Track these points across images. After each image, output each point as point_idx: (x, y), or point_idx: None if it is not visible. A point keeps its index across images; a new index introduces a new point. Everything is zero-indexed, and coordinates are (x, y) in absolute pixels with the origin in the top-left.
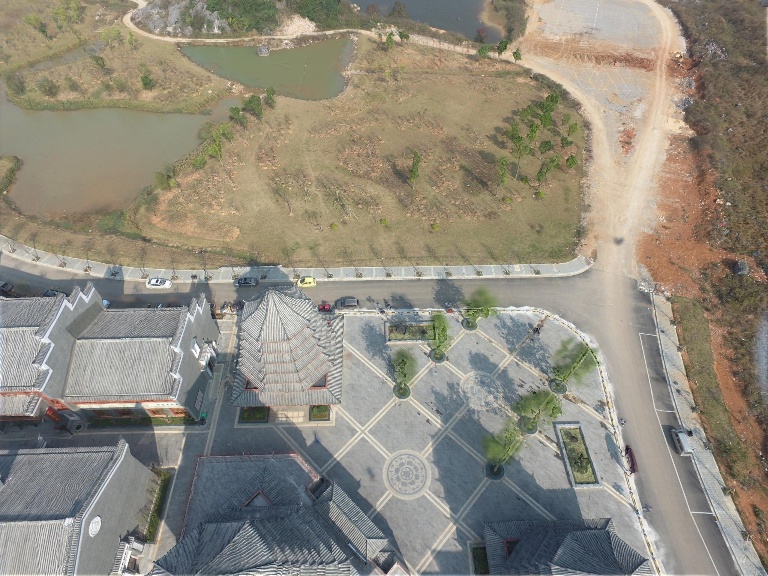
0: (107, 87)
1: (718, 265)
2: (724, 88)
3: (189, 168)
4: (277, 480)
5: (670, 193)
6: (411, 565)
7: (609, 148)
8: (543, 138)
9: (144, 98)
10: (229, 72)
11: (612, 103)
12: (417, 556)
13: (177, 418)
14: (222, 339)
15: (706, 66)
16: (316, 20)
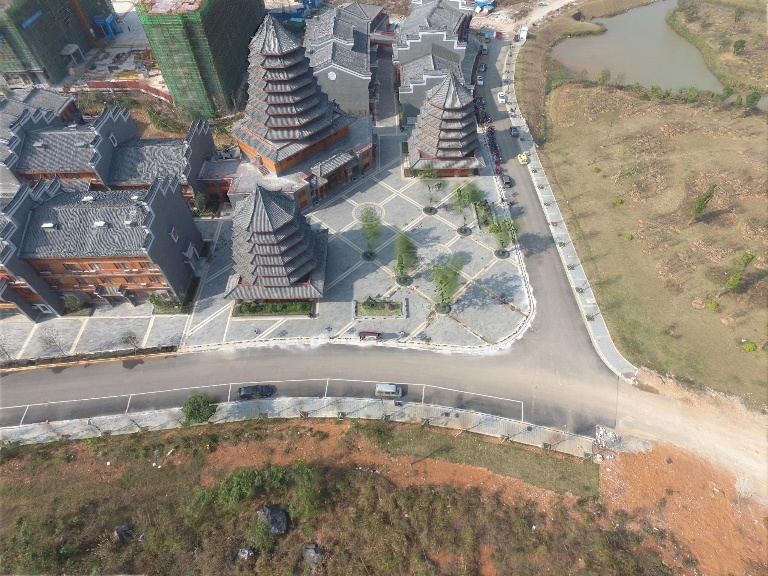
0: (720, 36)
1: (692, 568)
2: None
3: (639, 95)
4: (349, 123)
5: None
6: (315, 213)
7: None
8: None
9: (722, 56)
10: None
11: None
12: (319, 216)
13: None
14: None
15: None
16: None
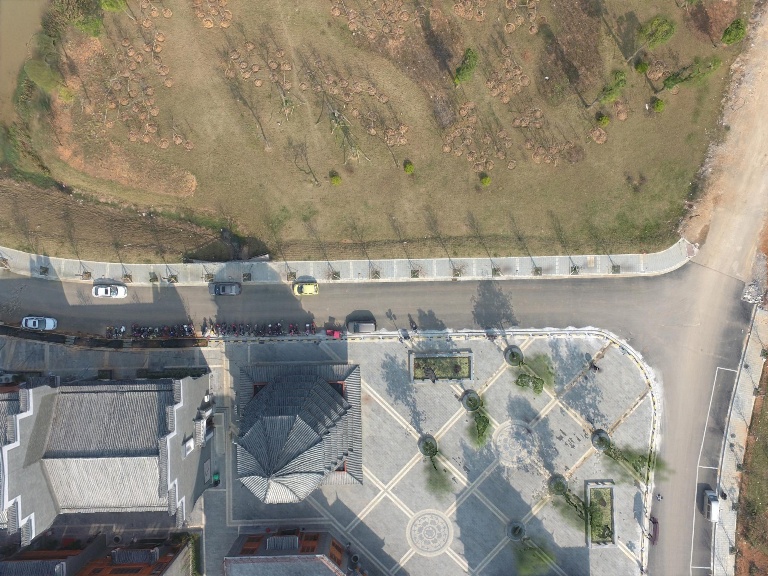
0: None
1: None
2: None
3: (78, 17)
4: None
5: None
6: None
7: None
8: None
9: None
10: None
11: None
12: None
13: None
14: (213, 377)
15: None
16: None
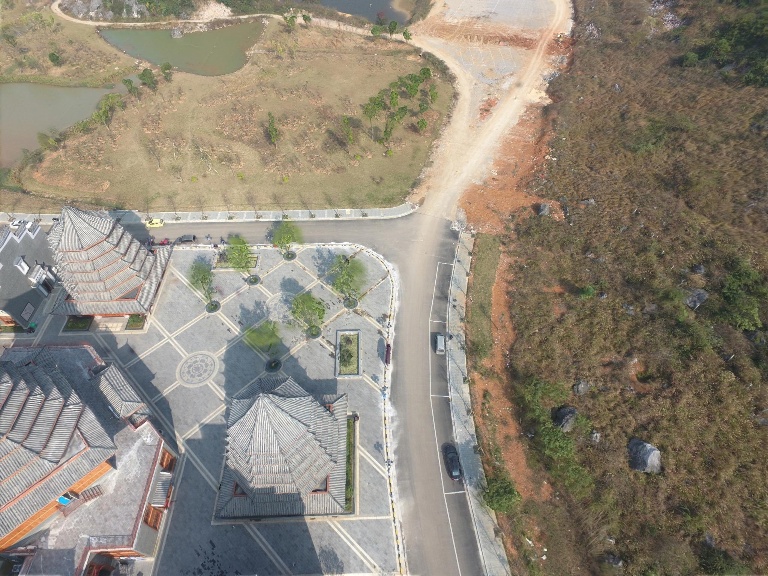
0: (20, 64)
1: (527, 208)
2: (588, 63)
3: (80, 133)
4: (52, 355)
5: (509, 151)
6: (179, 434)
7: (468, 115)
8: (411, 107)
9: (53, 74)
10: (140, 52)
11: (485, 77)
12: (186, 428)
13: (9, 327)
14: None
15: (580, 44)
16: (231, 5)
